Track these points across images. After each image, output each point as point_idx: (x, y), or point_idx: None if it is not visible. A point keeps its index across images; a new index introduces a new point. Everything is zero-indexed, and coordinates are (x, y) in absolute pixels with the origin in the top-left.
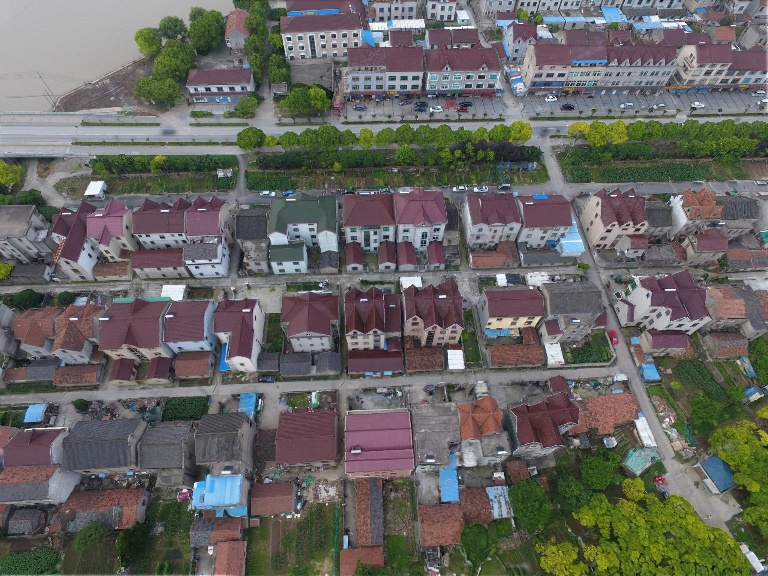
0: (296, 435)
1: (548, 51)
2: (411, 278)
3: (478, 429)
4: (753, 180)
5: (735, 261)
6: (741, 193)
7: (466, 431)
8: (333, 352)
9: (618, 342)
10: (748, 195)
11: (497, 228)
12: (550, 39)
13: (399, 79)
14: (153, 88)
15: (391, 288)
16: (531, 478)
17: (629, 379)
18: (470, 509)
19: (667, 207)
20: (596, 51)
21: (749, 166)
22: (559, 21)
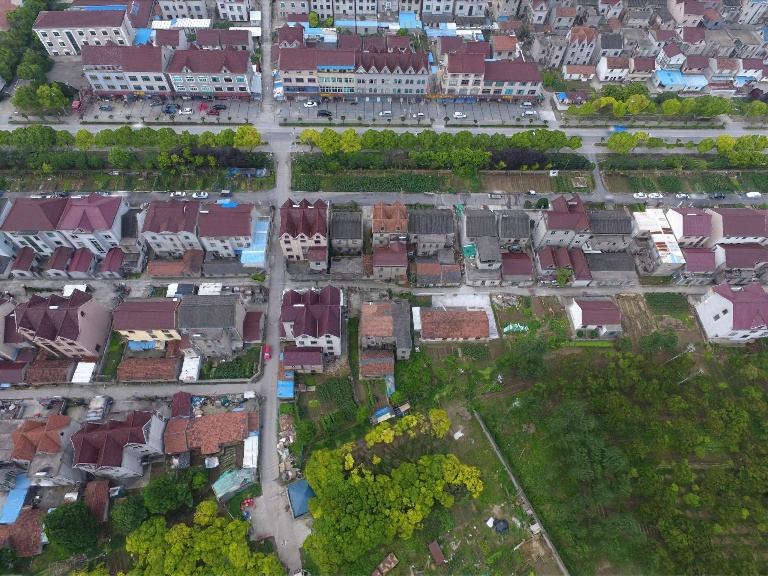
0: None
1: (293, 55)
2: (76, 286)
3: (32, 448)
4: (488, 193)
5: (424, 276)
6: (469, 206)
7: None
8: None
9: (271, 357)
10: (475, 208)
11: (170, 236)
12: (329, 43)
13: (141, 79)
14: None
15: None
16: (112, 499)
17: (265, 396)
18: (19, 531)
19: (359, 219)
20: (344, 57)
21: (490, 179)
22: (349, 25)
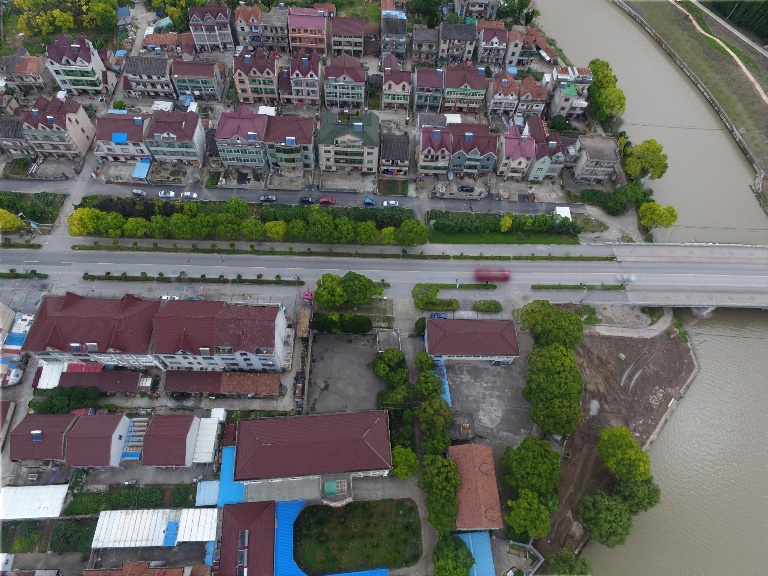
0: (353, 20)
1: None
2: None
3: None
4: None
5: None
6: None
7: (258, 10)
8: None
9: None
10: None
11: None
12: None
13: None
14: (553, 307)
15: None
16: None
17: None
18: None
19: (1, 122)
20: None
21: None
22: None
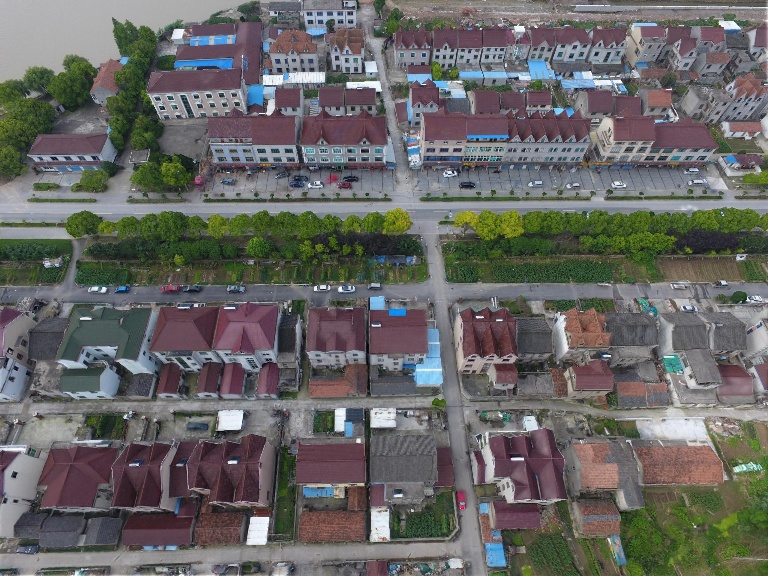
0: None
1: (440, 124)
2: (231, 412)
3: None
4: (669, 283)
5: (626, 397)
6: (652, 300)
7: None
8: (109, 518)
9: (466, 506)
10: (660, 303)
11: (337, 354)
12: (460, 100)
13: (270, 152)
14: None
15: (210, 422)
16: None
17: (470, 561)
18: None
19: (548, 329)
20: (496, 124)
21: (668, 264)
22: (477, 77)
